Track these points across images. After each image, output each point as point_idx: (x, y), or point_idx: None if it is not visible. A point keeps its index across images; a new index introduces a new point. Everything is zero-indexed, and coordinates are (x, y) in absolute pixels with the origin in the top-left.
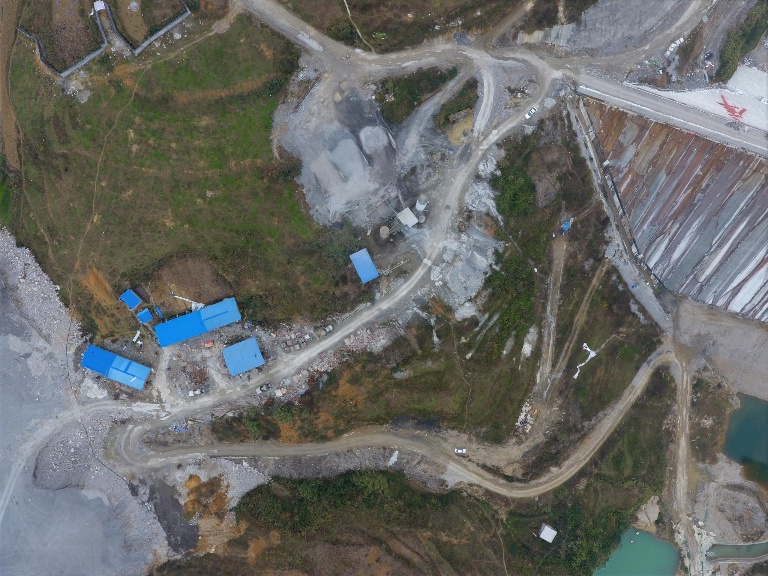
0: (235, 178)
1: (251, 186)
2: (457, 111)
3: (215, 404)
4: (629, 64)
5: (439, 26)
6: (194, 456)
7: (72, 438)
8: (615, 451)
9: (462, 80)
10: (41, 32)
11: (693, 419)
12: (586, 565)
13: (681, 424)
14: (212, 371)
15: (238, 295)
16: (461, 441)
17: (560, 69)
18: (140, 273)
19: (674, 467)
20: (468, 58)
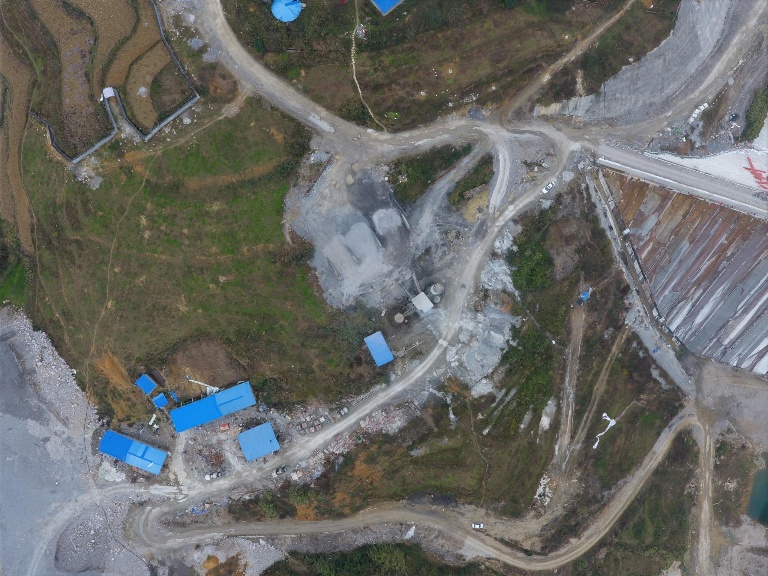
0: (247, 263)
1: (264, 270)
2: (472, 187)
3: (231, 487)
4: (650, 132)
5: (453, 103)
6: (211, 536)
7: (92, 520)
8: (636, 519)
9: (477, 156)
10: (52, 118)
11: (716, 482)
12: None
13: (704, 487)
14: (228, 454)
15: (252, 379)
16: (478, 515)
17: (578, 141)
18: (155, 358)
19: (696, 530)
20: (483, 134)
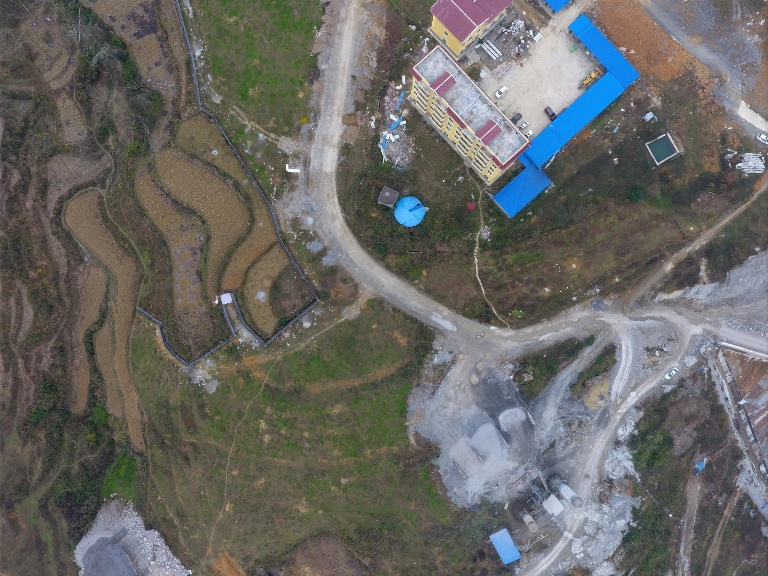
0: (370, 465)
1: (386, 471)
2: (594, 376)
3: None
4: None
5: (576, 296)
6: None
7: None
8: None
9: (599, 346)
10: (164, 320)
11: None
12: None
13: None
14: None
15: None
16: None
17: (700, 324)
18: (275, 561)
19: None
20: (605, 324)
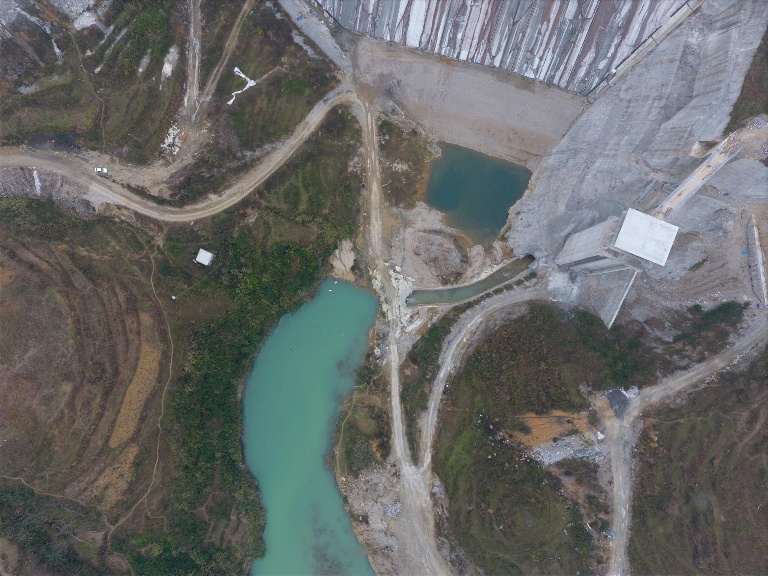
0: None
1: None
2: None
3: None
4: None
5: None
6: None
7: None
8: (286, 185)
9: None
10: None
11: (383, 163)
12: (255, 295)
13: (371, 168)
14: None
15: None
16: (103, 162)
17: None
18: None
19: (367, 213)
20: None
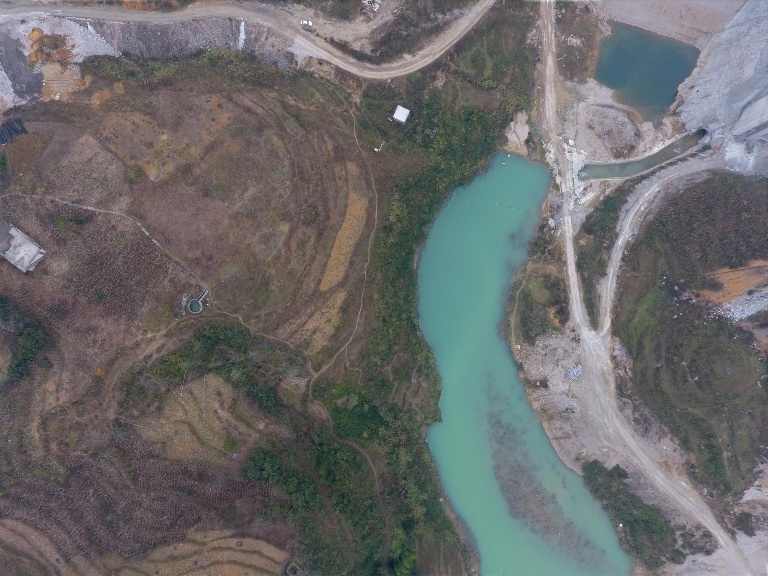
0: None
1: None
2: None
3: None
4: None
5: None
6: (38, 14)
7: None
8: (473, 50)
9: None
10: None
11: (559, 37)
12: (445, 156)
13: (547, 42)
14: None
15: None
16: (307, 15)
17: None
18: None
19: (542, 86)
20: None
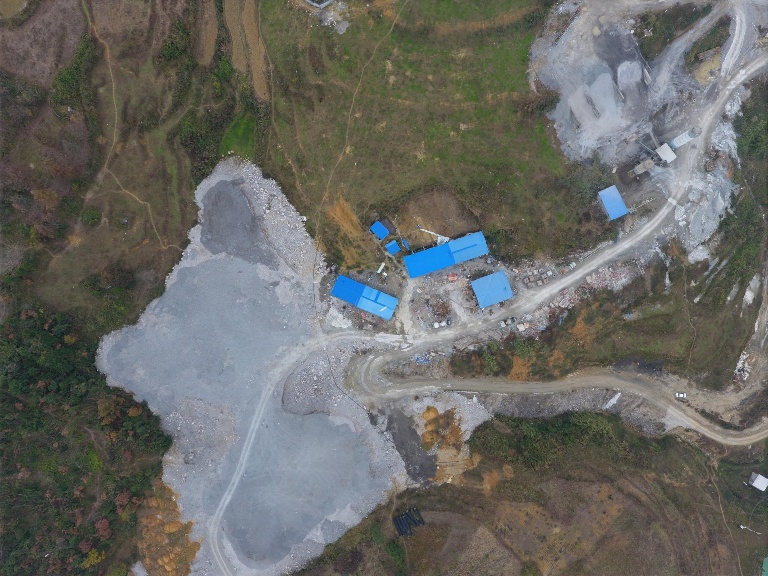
0: (490, 111)
1: (504, 120)
2: (707, 49)
3: (457, 337)
4: None
5: None
6: (429, 389)
7: (314, 366)
8: None
9: (715, 17)
10: None
11: None
12: None
13: None
14: (454, 304)
15: (484, 229)
16: (681, 386)
17: None
18: (390, 205)
19: None
20: None
